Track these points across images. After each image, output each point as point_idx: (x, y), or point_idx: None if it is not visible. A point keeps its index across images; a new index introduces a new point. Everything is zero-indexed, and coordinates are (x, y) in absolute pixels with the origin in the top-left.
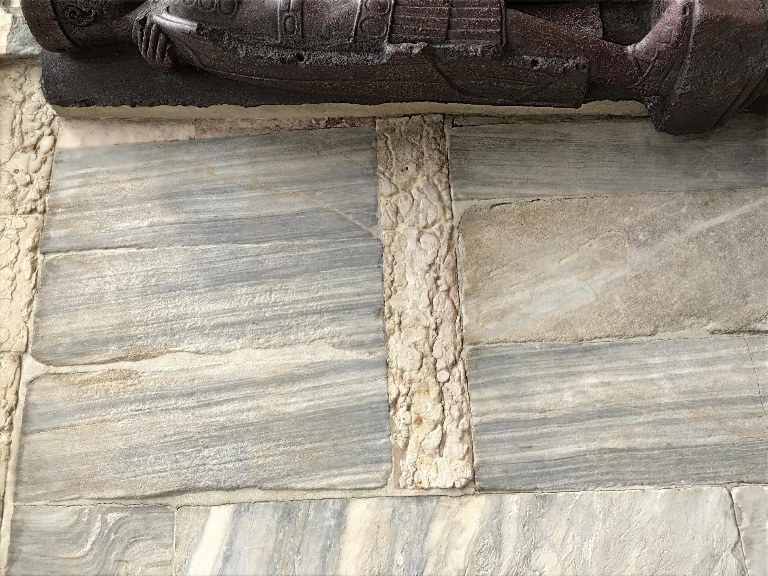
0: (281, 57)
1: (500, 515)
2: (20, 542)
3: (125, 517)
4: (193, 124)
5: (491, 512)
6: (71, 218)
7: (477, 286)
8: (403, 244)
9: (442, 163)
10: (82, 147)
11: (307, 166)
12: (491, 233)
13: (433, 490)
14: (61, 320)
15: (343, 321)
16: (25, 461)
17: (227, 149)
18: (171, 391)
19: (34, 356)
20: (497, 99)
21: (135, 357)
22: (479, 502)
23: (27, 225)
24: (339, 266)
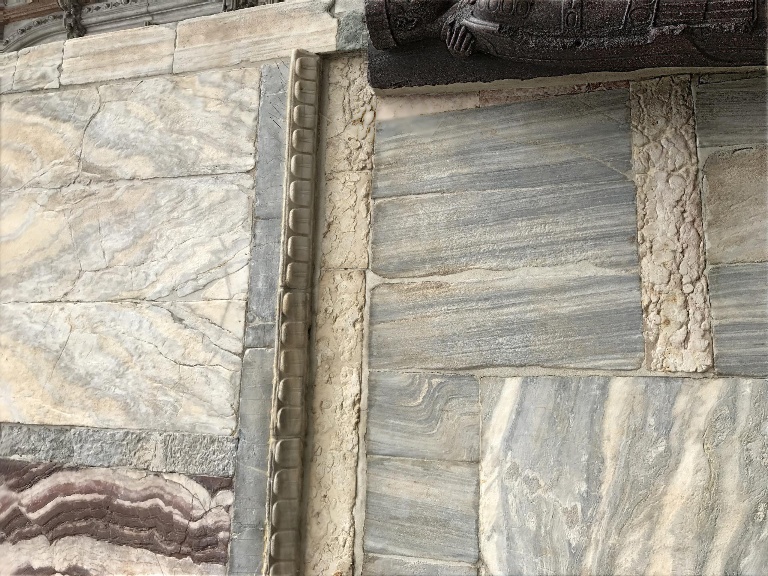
0: (563, 44)
1: (735, 394)
2: (375, 394)
3: (444, 382)
4: (478, 95)
5: (727, 391)
6: (391, 172)
7: (719, 218)
8: (654, 185)
9: (689, 116)
10: (395, 118)
11: (571, 124)
12: (732, 174)
13: (679, 373)
14: (390, 246)
15: (604, 246)
16: (374, 342)
17: (506, 114)
18: (472, 297)
19: (374, 271)
20: (744, 62)
21: (445, 272)
22: (717, 383)
23: (361, 178)
24: (600, 204)
